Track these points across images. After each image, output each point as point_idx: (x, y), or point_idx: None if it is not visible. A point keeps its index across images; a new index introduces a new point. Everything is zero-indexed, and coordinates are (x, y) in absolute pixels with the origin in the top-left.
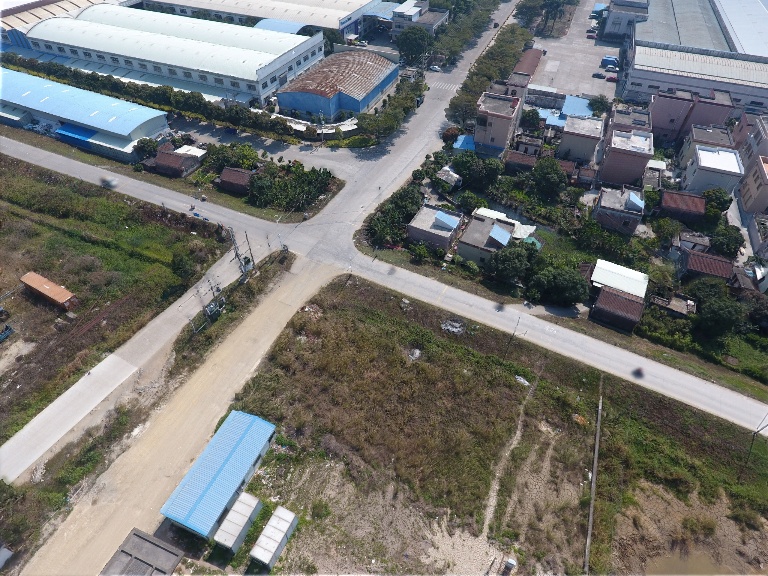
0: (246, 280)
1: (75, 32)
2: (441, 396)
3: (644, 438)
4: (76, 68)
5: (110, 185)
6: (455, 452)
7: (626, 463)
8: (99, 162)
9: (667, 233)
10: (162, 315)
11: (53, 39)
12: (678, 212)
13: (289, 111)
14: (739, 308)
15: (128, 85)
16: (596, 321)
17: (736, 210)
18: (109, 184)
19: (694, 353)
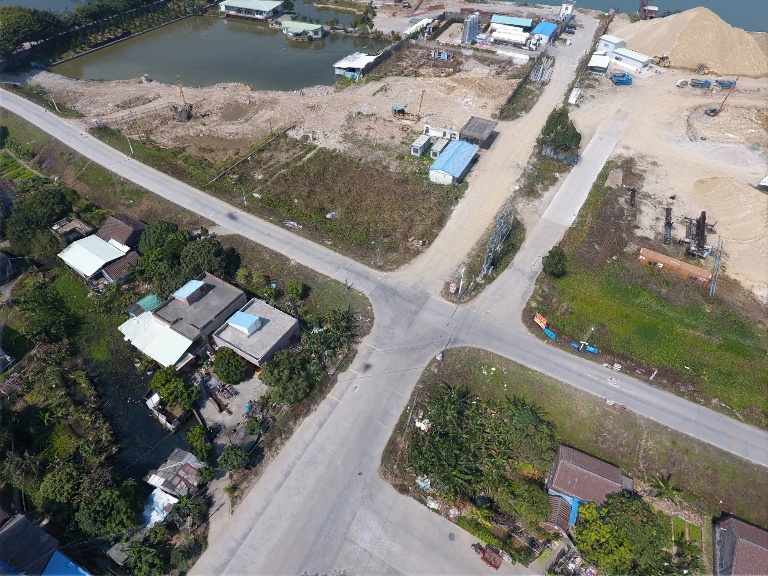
0: None
1: None
2: (320, 190)
3: None
4: None
5: None
6: None
7: None
8: None
9: None
10: None
11: None
12: None
13: None
14: None
15: None
16: None
17: None
18: None
19: None
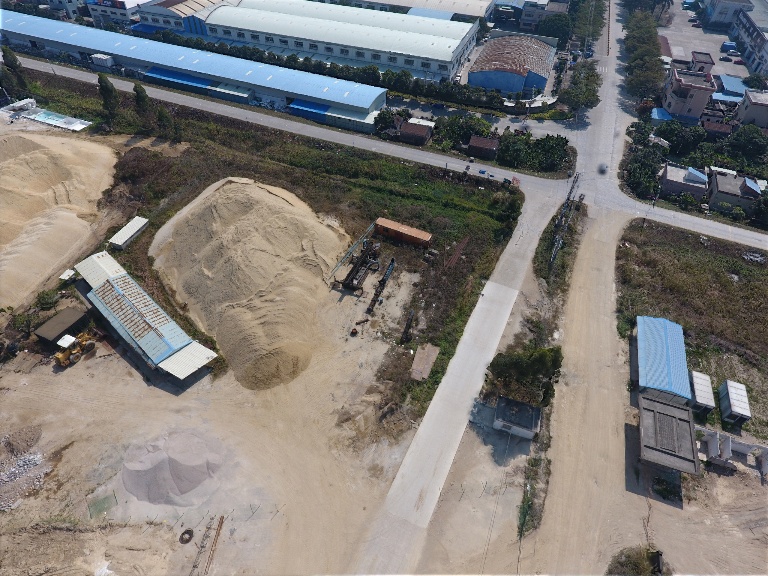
0: (562, 223)
1: (254, 18)
2: None
3: None
4: (271, 51)
5: (379, 150)
6: None
7: None
8: None
9: None
10: (506, 251)
11: (234, 25)
12: None
13: None
14: None
15: (333, 65)
16: None
17: None
18: (378, 149)
19: None
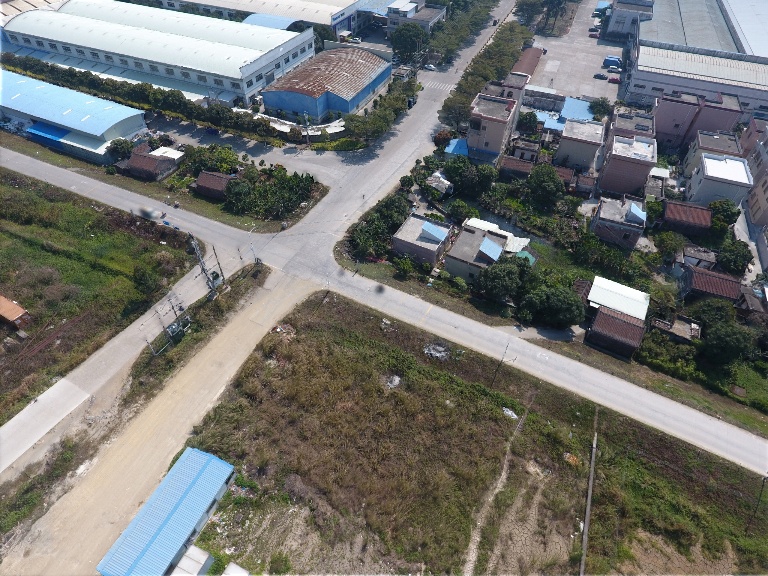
0: (215, 296)
1: (54, 25)
2: (420, 431)
3: (642, 481)
4: (53, 63)
5: (78, 189)
6: (433, 497)
7: (622, 511)
8: (69, 164)
9: (670, 248)
10: (121, 334)
11: (31, 32)
12: (682, 225)
13: (275, 111)
14: (748, 335)
15: (106, 82)
16: (592, 345)
17: (744, 222)
18: (77, 188)
19: (698, 382)
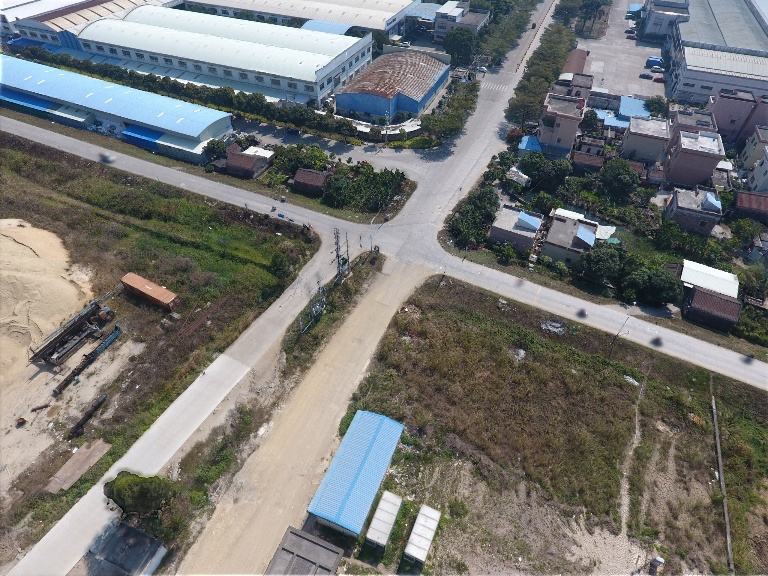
0: (342, 281)
1: (127, 33)
2: (555, 396)
3: (761, 437)
4: (132, 69)
5: (187, 186)
6: (580, 451)
7: (748, 462)
8: (170, 163)
9: (748, 234)
10: (264, 315)
11: (105, 40)
12: (753, 213)
13: None
14: None
15: (188, 86)
16: (691, 321)
17: None
18: (186, 185)
19: None
